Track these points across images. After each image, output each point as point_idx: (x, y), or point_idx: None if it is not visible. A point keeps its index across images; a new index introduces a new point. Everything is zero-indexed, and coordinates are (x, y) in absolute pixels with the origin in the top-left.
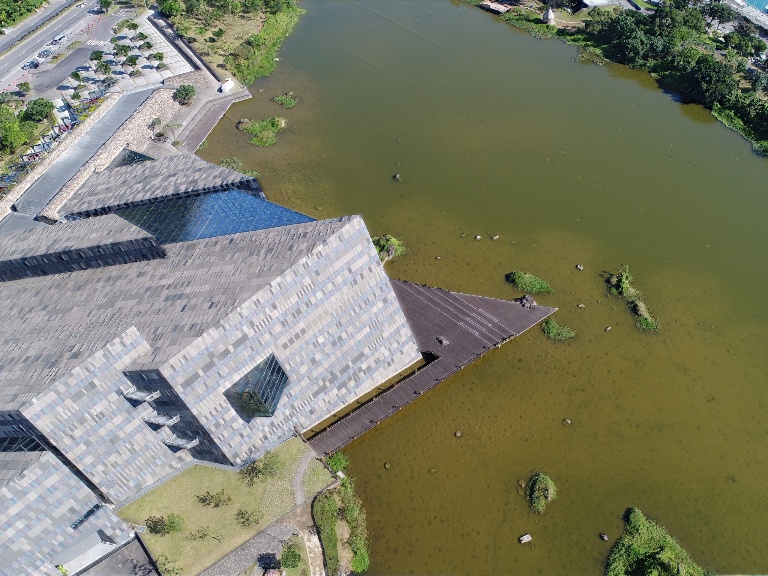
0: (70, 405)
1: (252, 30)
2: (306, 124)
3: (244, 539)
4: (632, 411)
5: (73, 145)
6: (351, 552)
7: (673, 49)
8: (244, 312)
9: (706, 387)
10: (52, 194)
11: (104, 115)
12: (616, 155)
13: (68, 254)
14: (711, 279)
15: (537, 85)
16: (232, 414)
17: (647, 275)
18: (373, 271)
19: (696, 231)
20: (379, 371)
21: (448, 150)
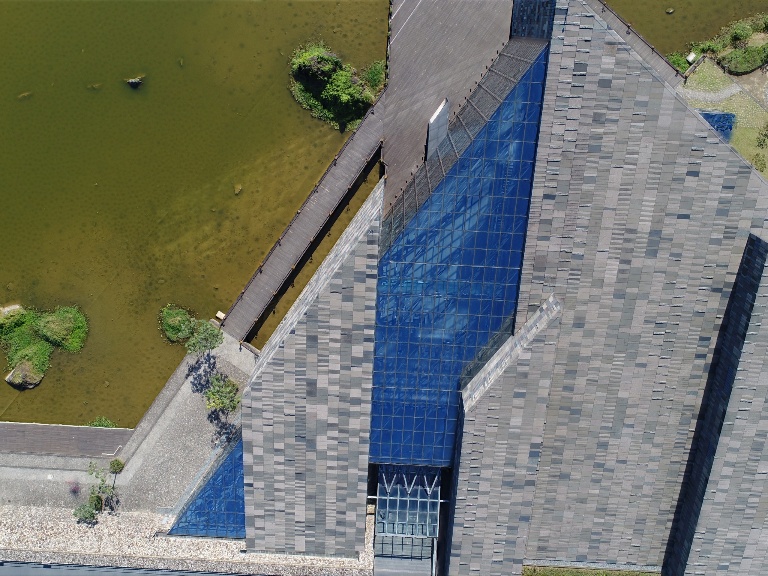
0: None
1: None
2: (1, 269)
3: None
4: None
5: None
6: None
7: None
8: None
9: None
10: None
11: None
12: None
13: None
14: None
15: None
16: None
17: None
18: None
19: None
20: None
21: (39, 9)
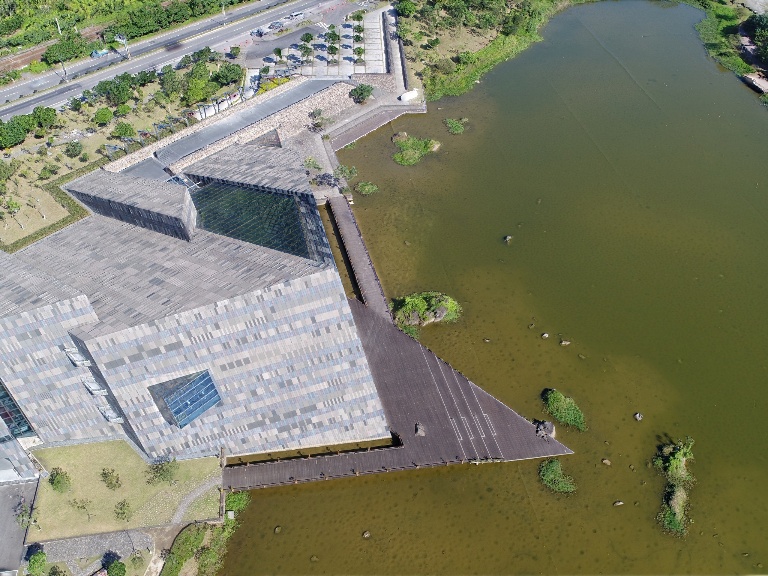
0: (15, 342)
1: (474, 46)
2: (458, 155)
3: (108, 529)
4: None
5: (238, 113)
6: None
7: None
8: (182, 320)
9: None
10: (191, 151)
11: (281, 93)
12: None
13: (133, 209)
14: None
15: (747, 187)
16: (155, 410)
17: (718, 462)
18: (343, 329)
19: None
20: (333, 431)
21: (584, 228)
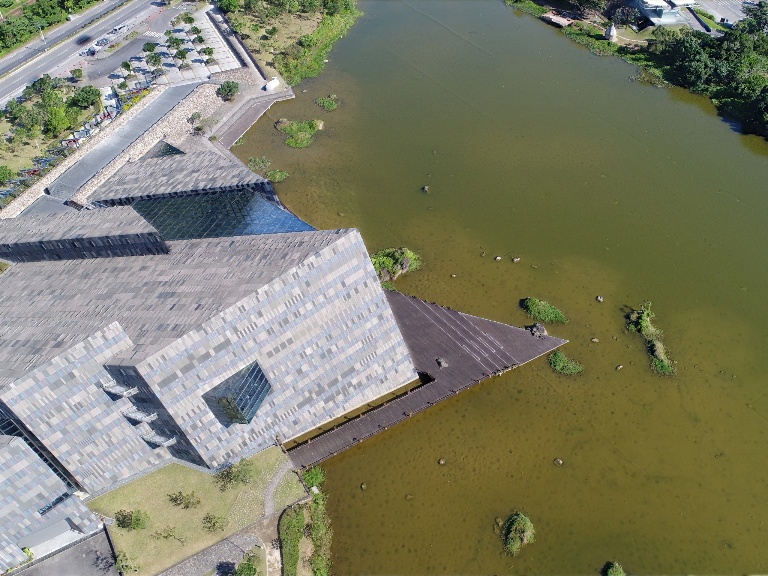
0: (48, 393)
1: (307, 30)
2: (344, 128)
3: (207, 544)
4: (630, 458)
5: (113, 133)
6: (311, 571)
7: (738, 75)
8: (228, 317)
9: (716, 441)
10: (85, 180)
11: (148, 106)
12: (659, 183)
13: (80, 242)
14: (741, 325)
15: (587, 104)
16: (210, 417)
17: (671, 314)
18: (369, 286)
19: (733, 271)
20: (371, 388)
21: (483, 165)
